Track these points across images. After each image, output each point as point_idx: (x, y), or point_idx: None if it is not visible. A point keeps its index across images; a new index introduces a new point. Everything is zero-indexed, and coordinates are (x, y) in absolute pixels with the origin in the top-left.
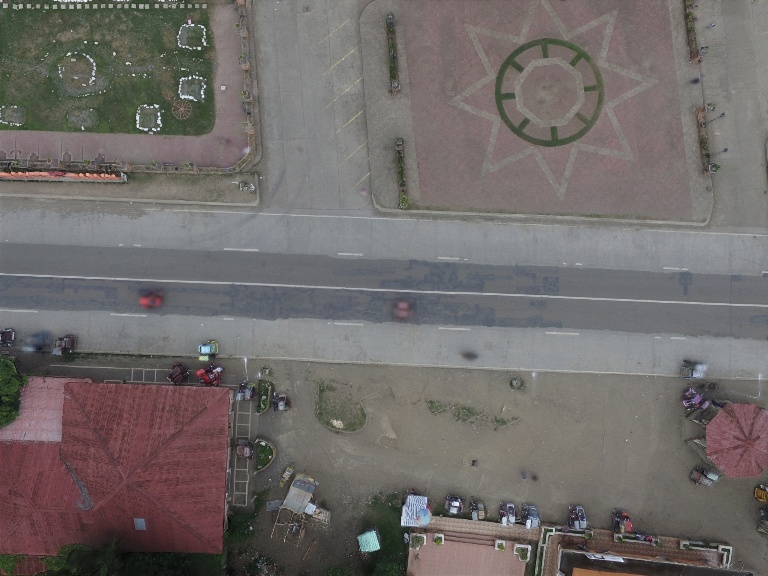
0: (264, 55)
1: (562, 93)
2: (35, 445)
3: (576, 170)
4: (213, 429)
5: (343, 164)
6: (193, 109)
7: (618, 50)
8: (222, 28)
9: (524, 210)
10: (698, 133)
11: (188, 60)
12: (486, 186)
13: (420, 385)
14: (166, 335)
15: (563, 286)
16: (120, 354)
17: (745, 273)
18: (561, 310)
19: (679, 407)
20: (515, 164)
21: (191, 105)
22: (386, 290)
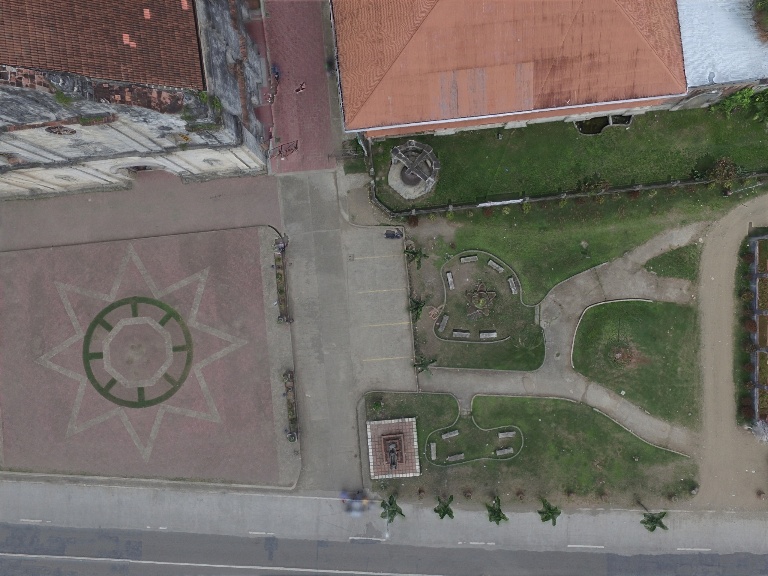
0: None
1: (150, 353)
2: None
3: (162, 432)
4: None
5: None
6: None
7: (208, 310)
8: None
9: (108, 472)
10: (286, 396)
11: None
12: (70, 447)
13: None
14: None
15: (146, 550)
16: None
17: (332, 539)
18: (144, 574)
19: None
20: (100, 425)
21: None
22: None
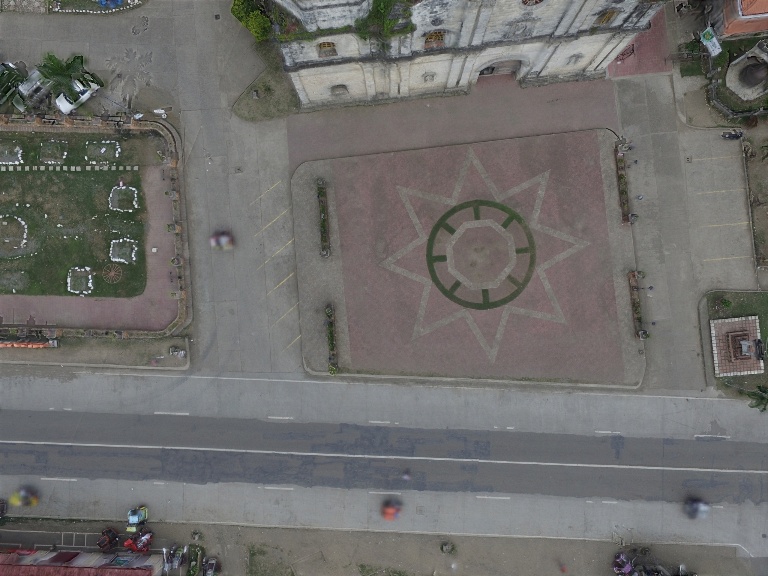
0: (196, 216)
1: (493, 255)
2: None
3: (507, 333)
4: None
5: (274, 326)
6: (124, 272)
7: (550, 212)
8: (154, 189)
9: (455, 374)
10: (630, 296)
11: (119, 222)
12: (417, 349)
13: (351, 549)
14: (96, 499)
15: (494, 450)
16: (50, 518)
17: (677, 436)
18: (492, 474)
19: (611, 572)
20: (446, 327)
21: (121, 269)
22: (316, 454)
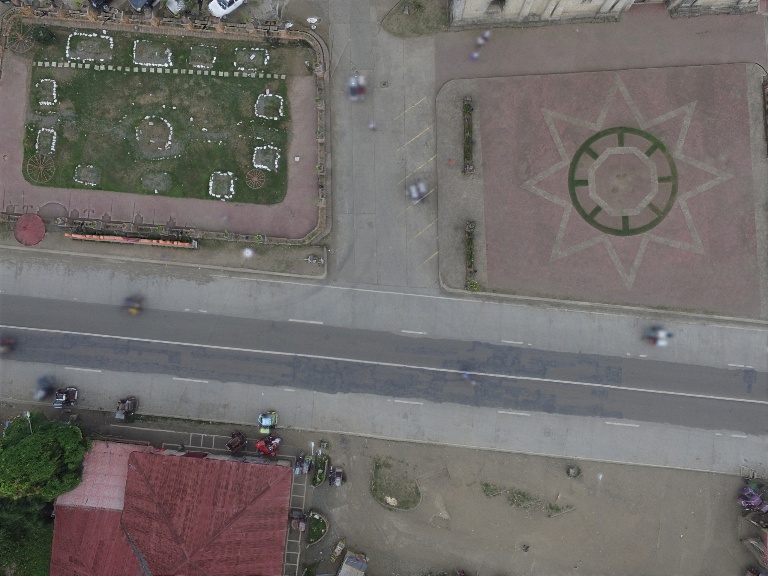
0: (339, 128)
1: (635, 183)
2: (97, 512)
3: (645, 261)
4: (275, 508)
5: (412, 241)
6: (266, 179)
7: (694, 143)
8: (299, 99)
9: (591, 298)
10: None
11: (264, 129)
12: (554, 272)
13: (476, 467)
14: (226, 402)
15: (626, 377)
16: (180, 418)
17: None
18: (622, 401)
19: (737, 506)
20: (584, 251)
21: (265, 175)
22: (448, 370)
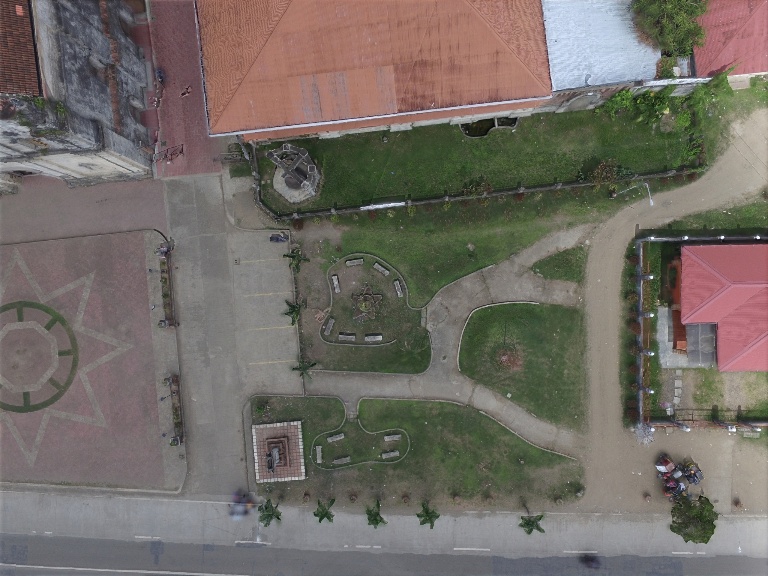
0: None
1: (36, 357)
2: None
3: (47, 437)
4: None
5: None
6: None
7: (93, 314)
8: None
9: None
10: (171, 400)
11: None
12: None
13: None
14: None
15: (32, 555)
16: None
17: (218, 542)
18: None
19: None
20: None
21: None
22: None
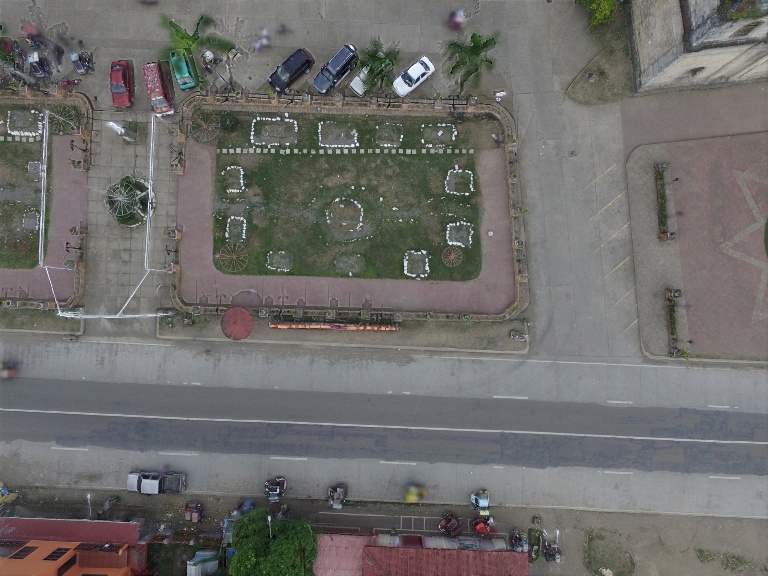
0: (530, 200)
1: None
2: None
3: None
4: None
5: (611, 310)
6: None
7: None
8: (488, 173)
9: None
10: None
11: (455, 205)
12: (756, 334)
13: (689, 534)
14: (436, 483)
15: None
16: (390, 502)
17: None
18: None
19: None
20: None
21: (461, 252)
22: (656, 438)
